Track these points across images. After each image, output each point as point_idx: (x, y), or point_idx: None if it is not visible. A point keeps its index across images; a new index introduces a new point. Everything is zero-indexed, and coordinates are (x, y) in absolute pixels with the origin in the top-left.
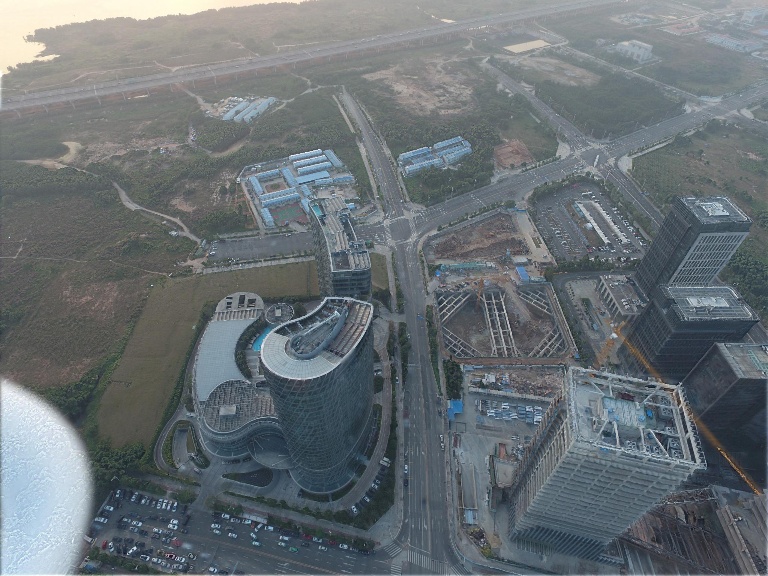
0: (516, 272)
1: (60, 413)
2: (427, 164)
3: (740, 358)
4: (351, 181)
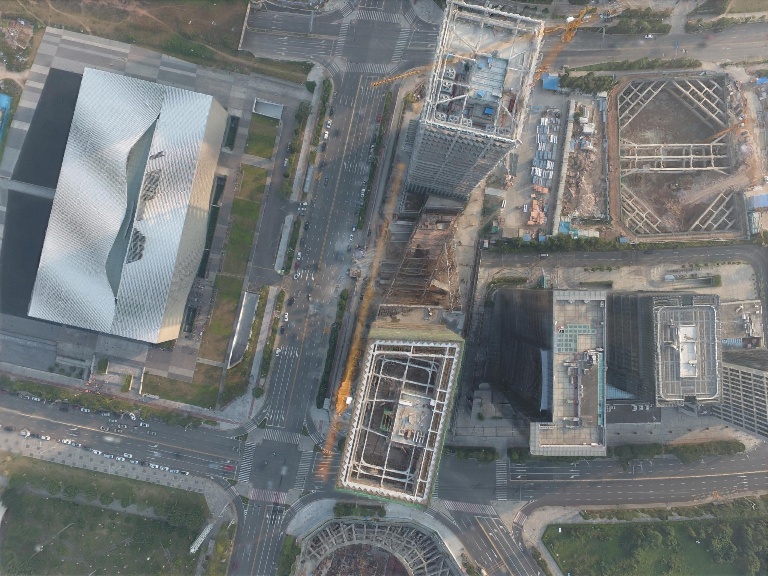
0: None
1: None
2: None
3: (584, 312)
4: None
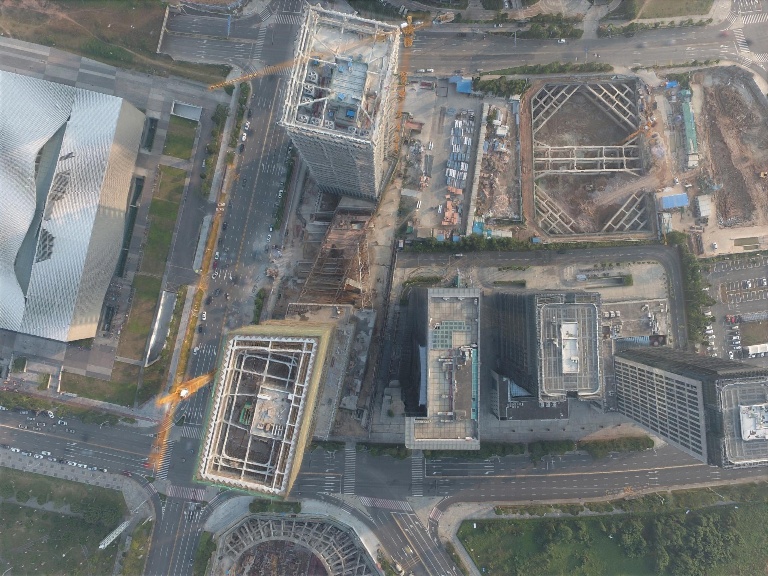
0: None
1: None
2: None
3: (459, 309)
4: None
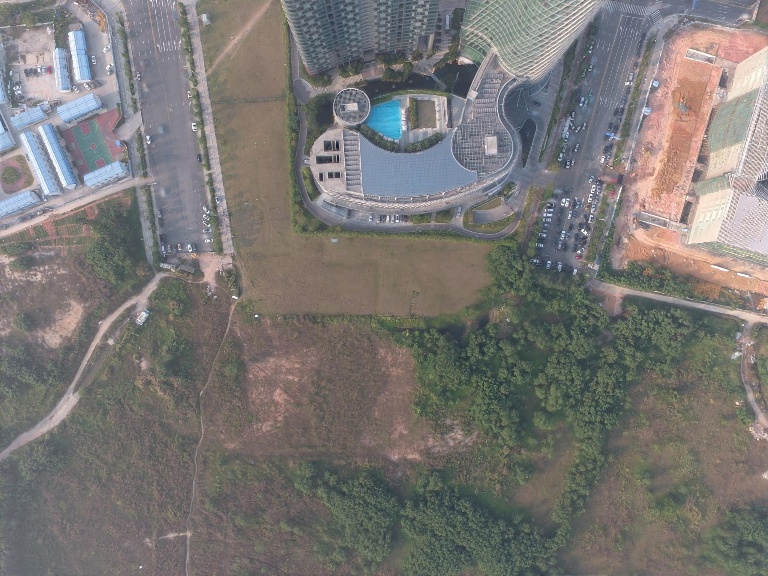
0: None
1: (457, 347)
2: None
3: None
4: None
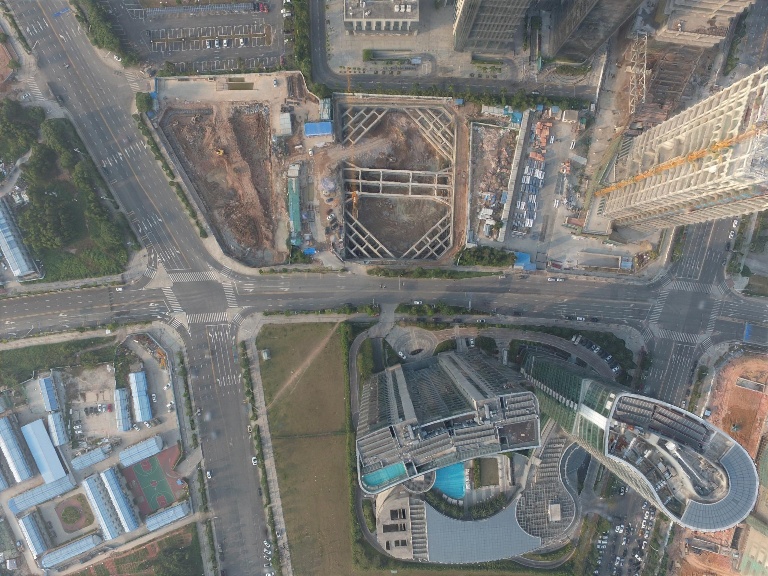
0: (311, 137)
1: None
2: (6, 233)
3: None
4: (55, 379)
